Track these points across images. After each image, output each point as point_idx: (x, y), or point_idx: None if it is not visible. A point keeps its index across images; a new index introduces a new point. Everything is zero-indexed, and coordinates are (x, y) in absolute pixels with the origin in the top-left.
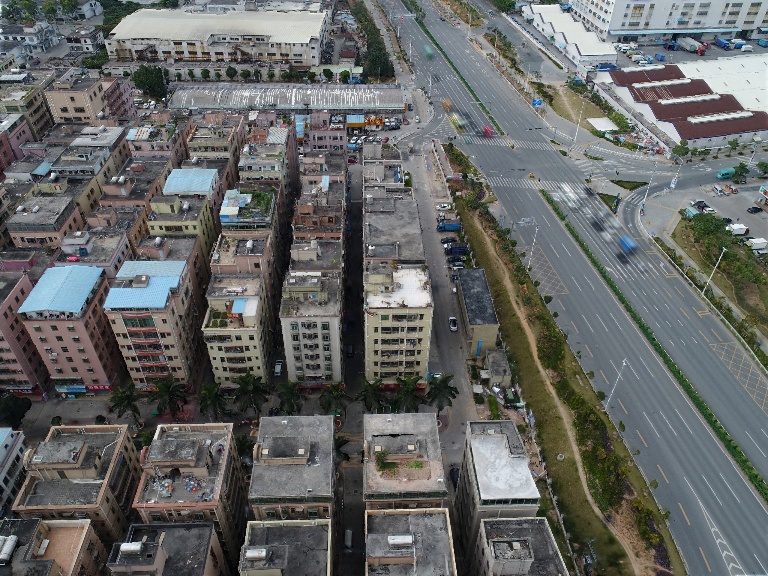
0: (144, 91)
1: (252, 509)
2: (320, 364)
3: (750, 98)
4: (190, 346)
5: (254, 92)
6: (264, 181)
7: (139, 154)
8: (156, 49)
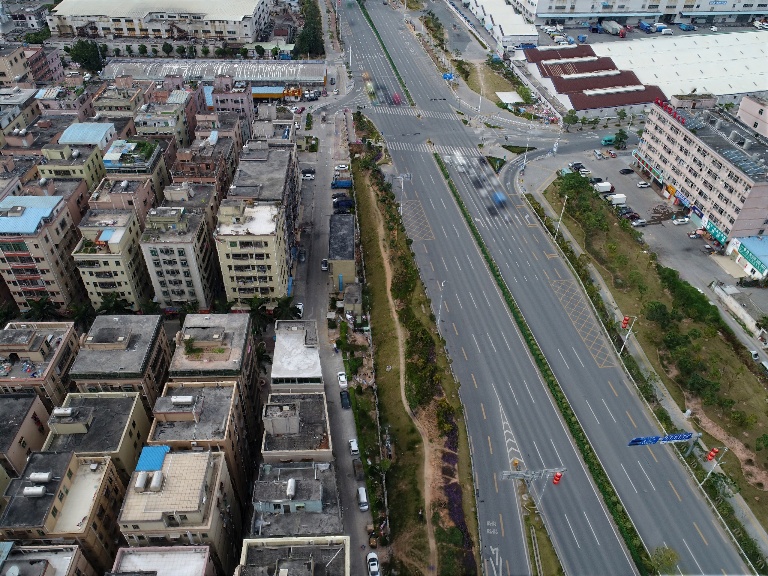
0: (82, 65)
1: None
2: (184, 290)
3: (649, 74)
4: (71, 276)
5: (183, 65)
6: (158, 136)
7: (48, 112)
8: (96, 25)
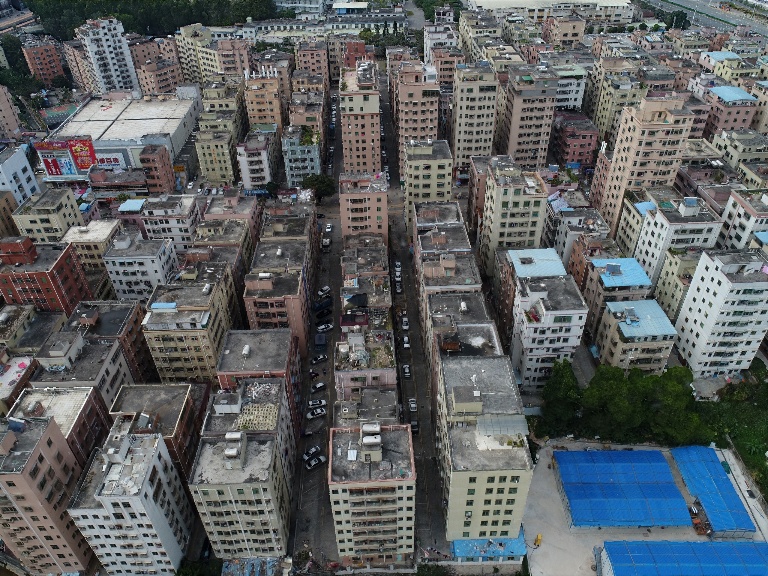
0: None
1: None
2: None
3: None
4: None
5: (615, 36)
6: None
7: (651, 52)
8: None
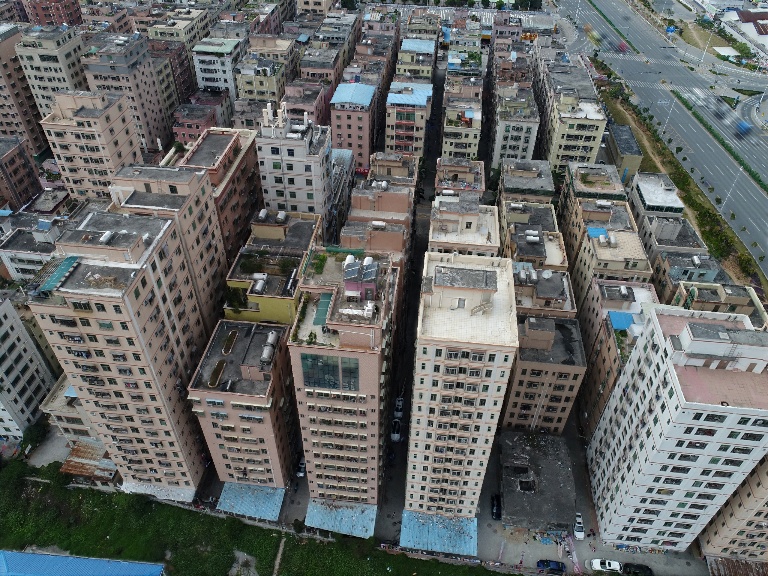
0: None
1: None
2: None
3: None
4: (423, 149)
5: (429, 10)
6: None
7: (370, 33)
8: None
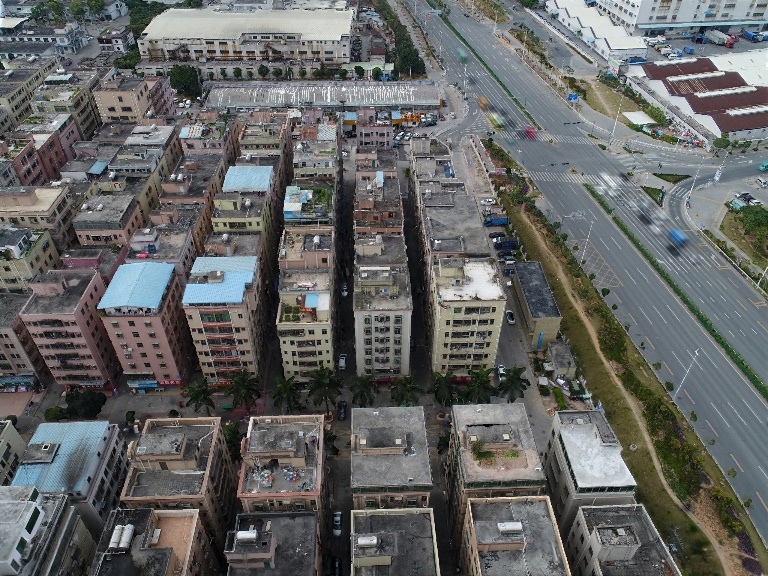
0: (178, 90)
1: (332, 500)
2: (389, 357)
3: None
4: (258, 341)
5: (289, 90)
6: (318, 177)
7: (191, 152)
8: (188, 48)
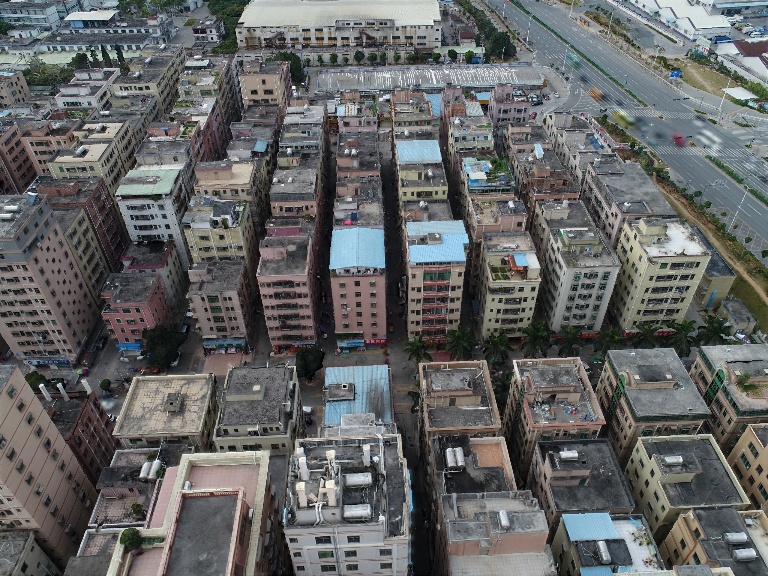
0: None
1: None
2: (586, 314)
3: None
4: None
5: (394, 73)
6: None
7: (346, 130)
8: (284, 36)
